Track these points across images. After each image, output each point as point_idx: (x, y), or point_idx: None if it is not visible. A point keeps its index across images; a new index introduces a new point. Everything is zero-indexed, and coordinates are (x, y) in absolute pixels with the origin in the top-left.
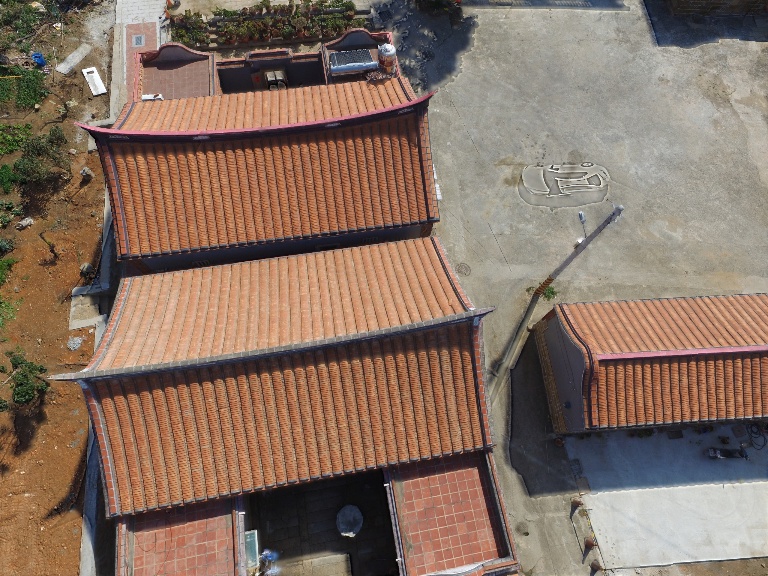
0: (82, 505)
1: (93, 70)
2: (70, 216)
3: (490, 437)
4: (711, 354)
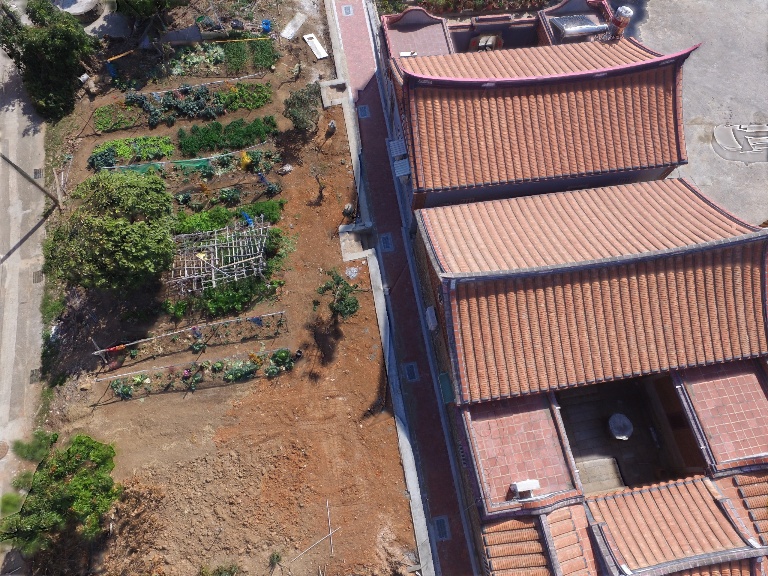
0: (391, 407)
1: (312, 36)
2: (323, 164)
3: None
4: None
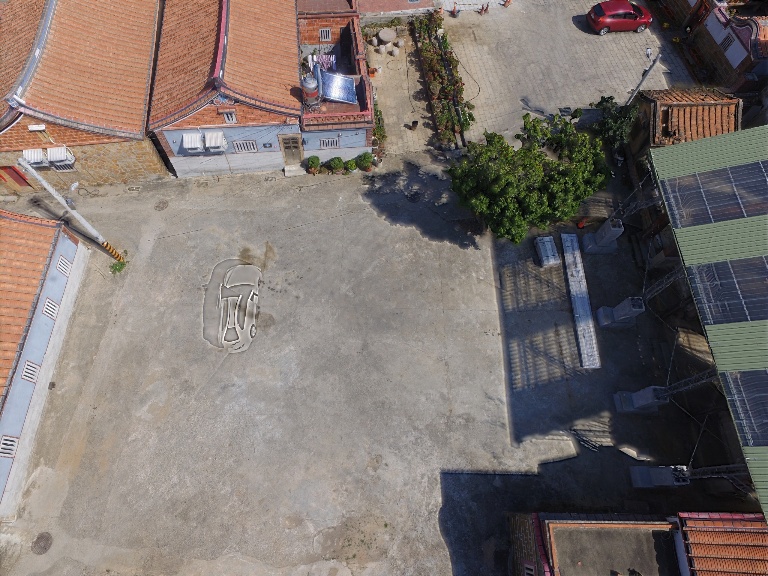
0: None
1: None
2: None
3: None
4: None
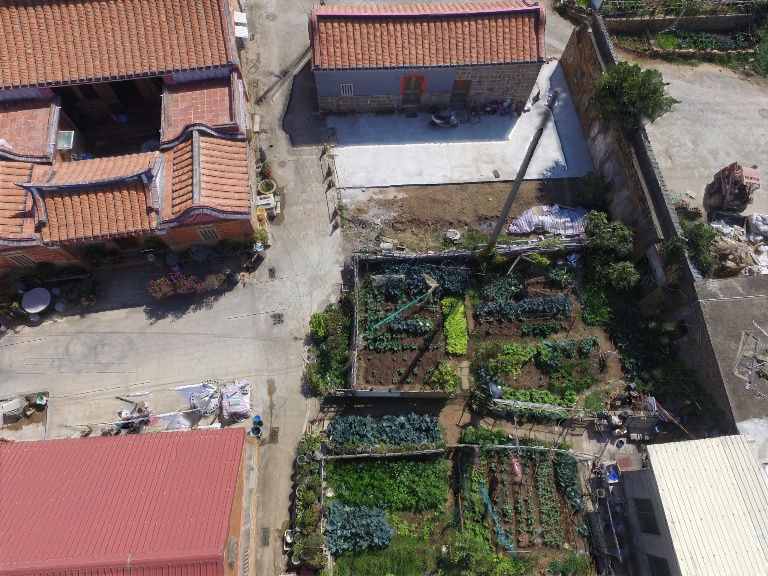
0: None
1: None
2: None
3: (231, 57)
4: (403, 17)
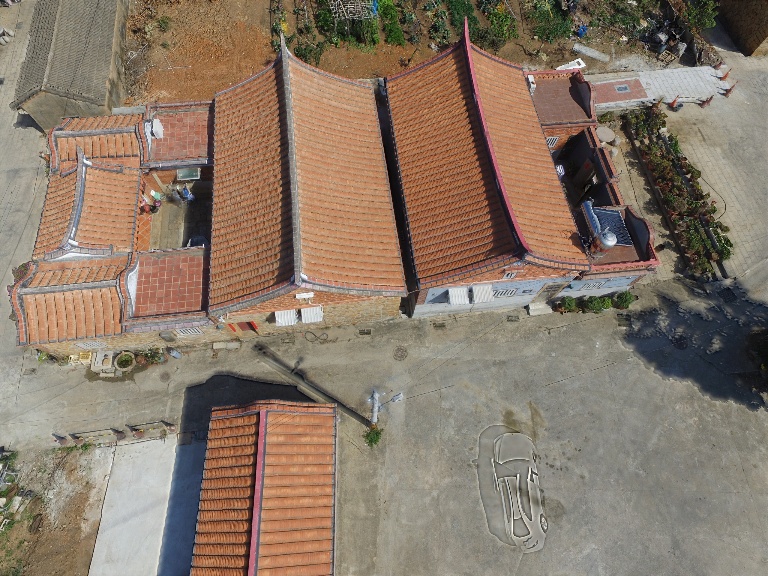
0: None
1: (582, 65)
2: None
3: (214, 309)
4: None
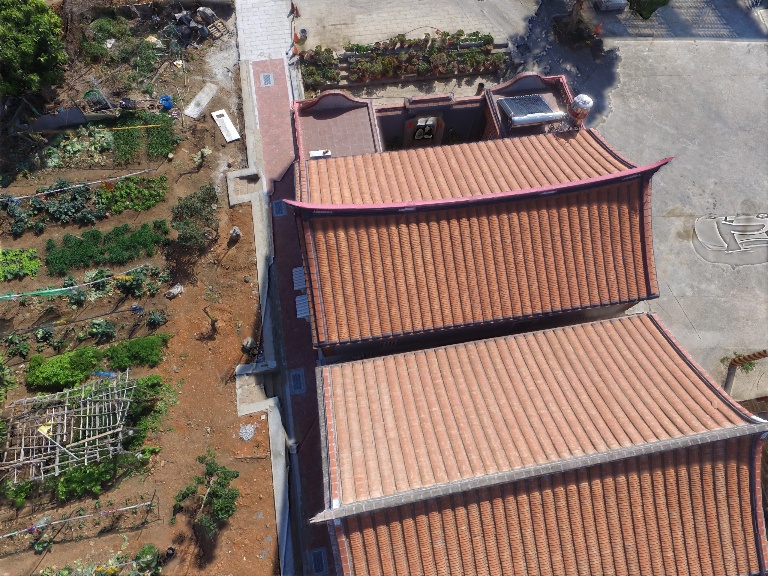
0: None
1: (223, 113)
2: (222, 282)
3: None
4: None
